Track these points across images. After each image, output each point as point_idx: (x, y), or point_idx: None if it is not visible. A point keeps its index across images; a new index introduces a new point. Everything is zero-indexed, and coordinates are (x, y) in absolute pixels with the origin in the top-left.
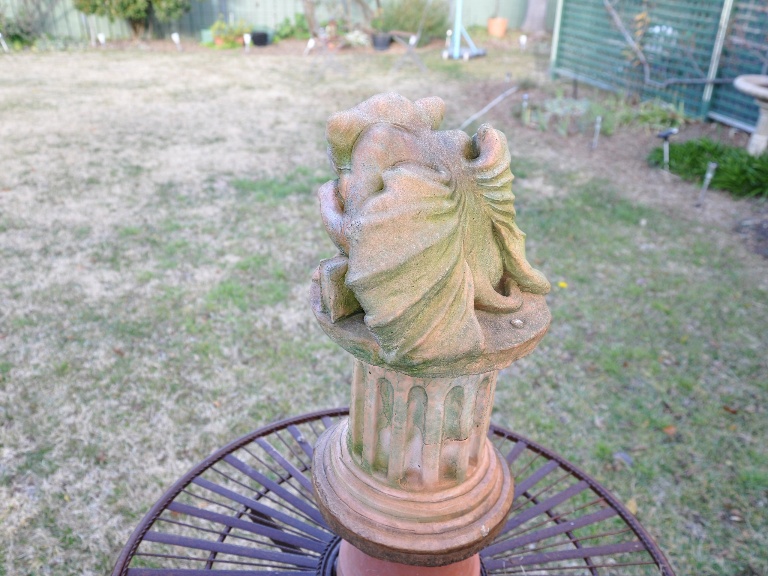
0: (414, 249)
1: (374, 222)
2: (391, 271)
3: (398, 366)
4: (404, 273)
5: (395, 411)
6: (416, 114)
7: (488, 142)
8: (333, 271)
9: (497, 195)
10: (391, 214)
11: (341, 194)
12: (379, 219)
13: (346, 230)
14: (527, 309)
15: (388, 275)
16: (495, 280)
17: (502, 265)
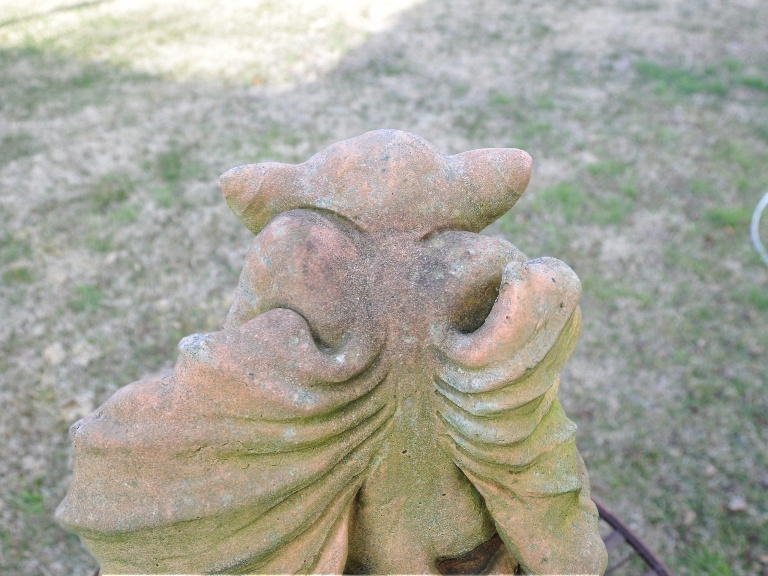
0: (152, 516)
1: (91, 444)
2: (105, 534)
3: None
4: (135, 542)
5: None
6: (397, 205)
7: (494, 313)
8: None
9: (466, 428)
10: (126, 441)
11: None
12: (100, 443)
13: None
14: None
15: (102, 536)
16: (455, 548)
17: (486, 526)
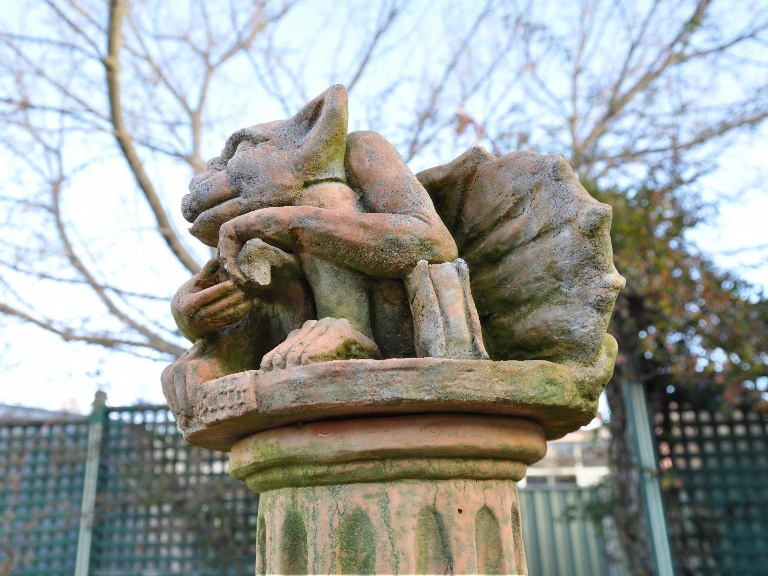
0: None
1: None
2: None
3: (606, 379)
4: None
5: (510, 571)
6: None
7: None
8: None
9: None
10: None
11: None
12: None
13: (561, 158)
14: None
15: None
16: None
17: None
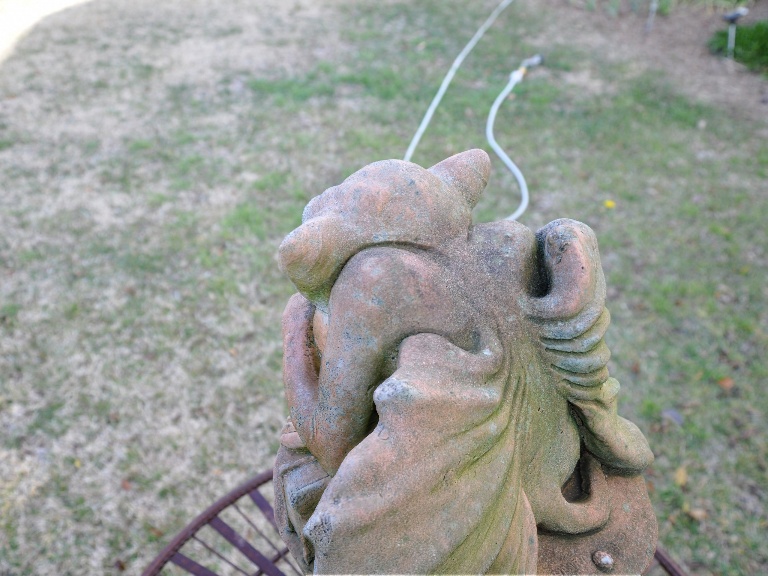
0: (434, 559)
1: (356, 527)
2: None
3: None
4: None
5: None
6: (442, 217)
7: (567, 270)
8: (301, 502)
9: (580, 366)
10: (390, 504)
11: (317, 346)
12: (366, 520)
13: (305, 533)
14: (618, 523)
15: None
16: (567, 475)
17: None
